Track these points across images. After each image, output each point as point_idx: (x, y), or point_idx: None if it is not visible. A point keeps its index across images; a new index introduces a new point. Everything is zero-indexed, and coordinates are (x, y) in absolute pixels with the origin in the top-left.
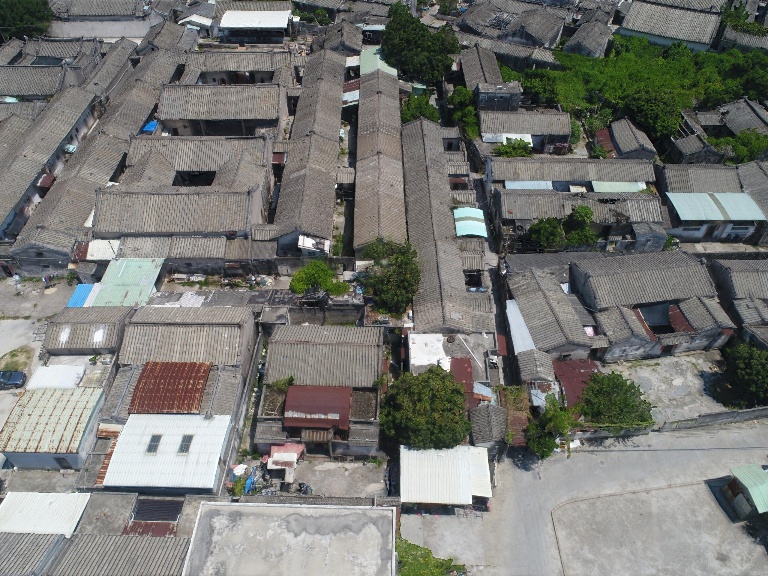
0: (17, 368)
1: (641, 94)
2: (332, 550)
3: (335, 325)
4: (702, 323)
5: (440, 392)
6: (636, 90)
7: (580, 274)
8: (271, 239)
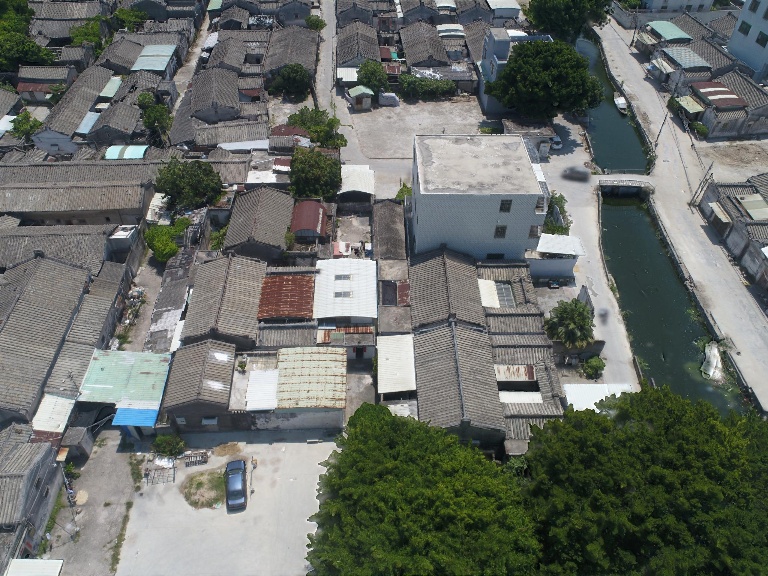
0: (217, 478)
1: (8, 44)
2: (439, 152)
3: (209, 244)
4: (258, 83)
5: (314, 156)
6: (1, 44)
7: (208, 111)
8: (102, 262)
